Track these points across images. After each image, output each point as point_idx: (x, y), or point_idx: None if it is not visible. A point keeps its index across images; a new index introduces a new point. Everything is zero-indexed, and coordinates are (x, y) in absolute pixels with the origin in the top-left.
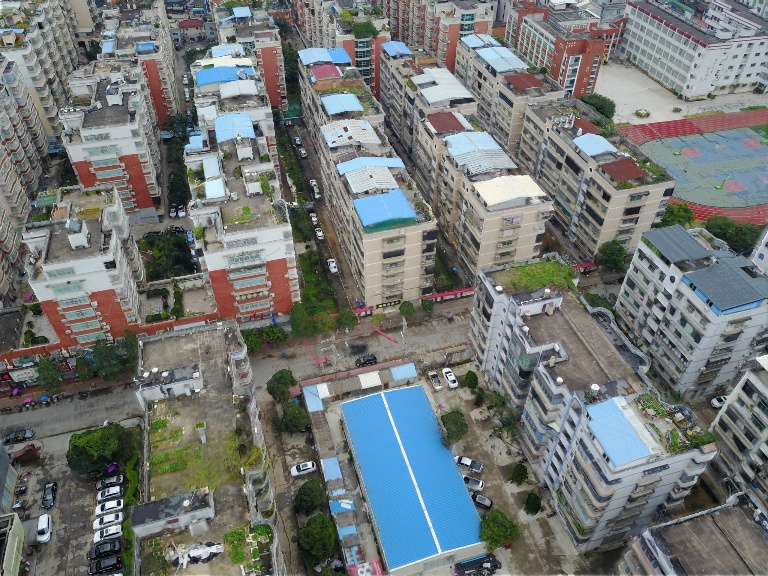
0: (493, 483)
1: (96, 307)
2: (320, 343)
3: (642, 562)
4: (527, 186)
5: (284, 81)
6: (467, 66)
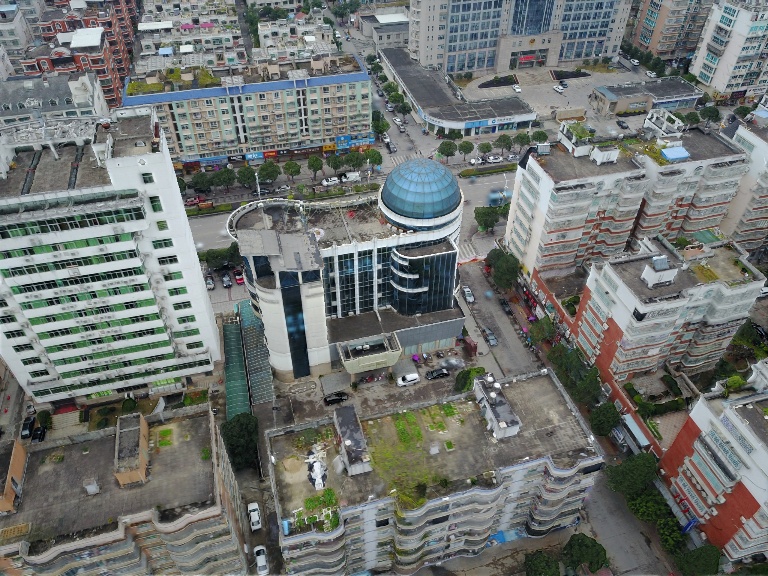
0: None
1: (604, 330)
2: None
3: None
4: None
5: None
6: None
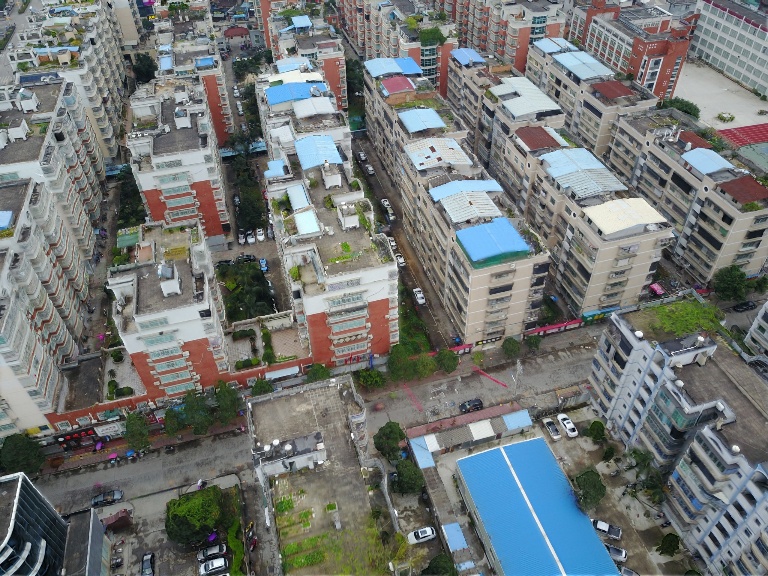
0: (635, 551)
1: (188, 357)
2: (419, 386)
3: None
4: (644, 211)
5: (346, 93)
6: (542, 72)
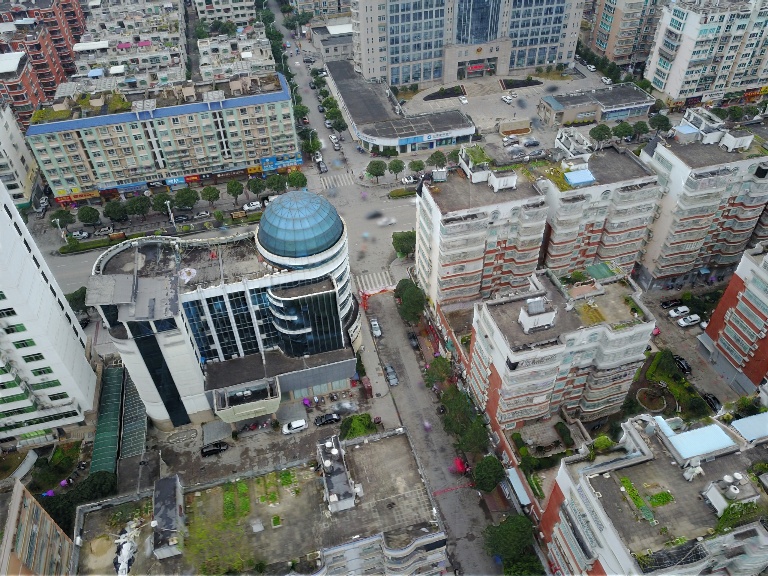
0: None
1: (488, 375)
2: None
3: None
4: None
5: None
6: None
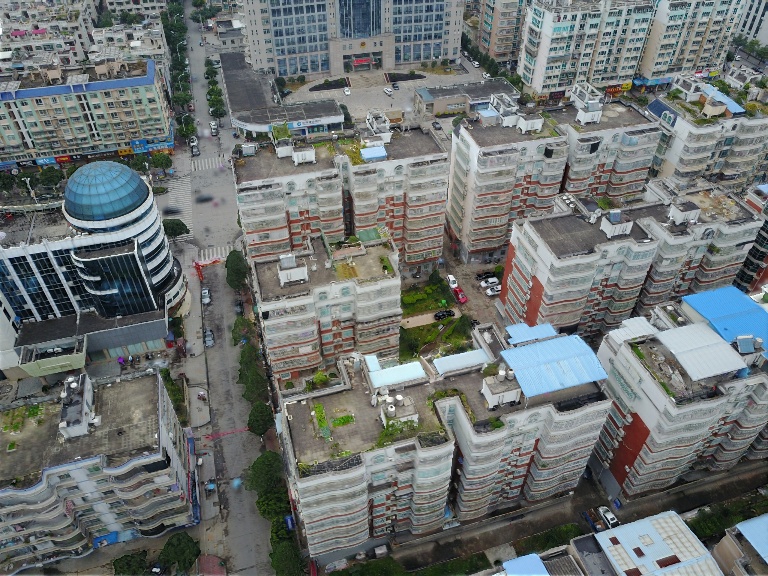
0: None
1: None
2: None
3: None
4: None
5: None
6: None
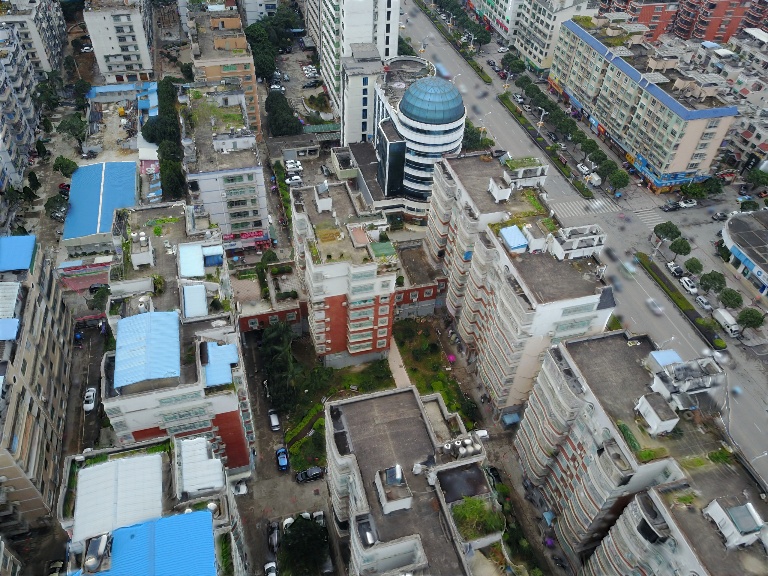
0: None
1: None
2: None
3: (8, 95)
4: None
5: None
6: None
